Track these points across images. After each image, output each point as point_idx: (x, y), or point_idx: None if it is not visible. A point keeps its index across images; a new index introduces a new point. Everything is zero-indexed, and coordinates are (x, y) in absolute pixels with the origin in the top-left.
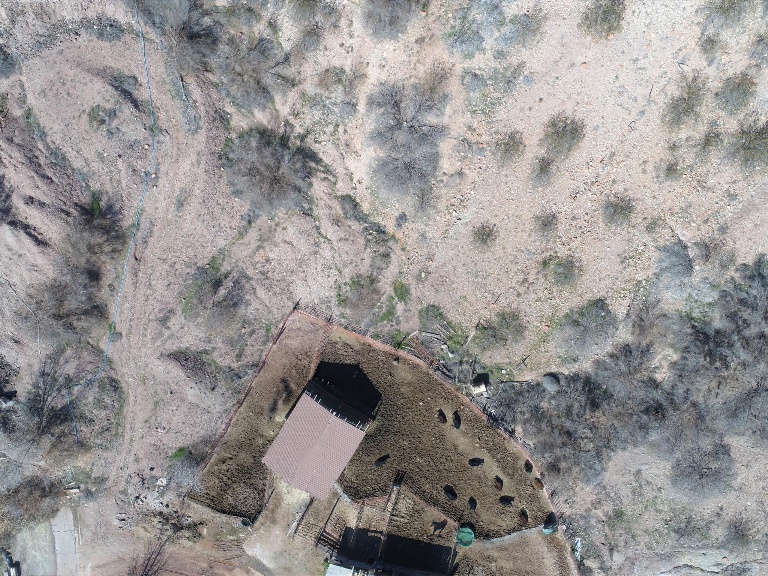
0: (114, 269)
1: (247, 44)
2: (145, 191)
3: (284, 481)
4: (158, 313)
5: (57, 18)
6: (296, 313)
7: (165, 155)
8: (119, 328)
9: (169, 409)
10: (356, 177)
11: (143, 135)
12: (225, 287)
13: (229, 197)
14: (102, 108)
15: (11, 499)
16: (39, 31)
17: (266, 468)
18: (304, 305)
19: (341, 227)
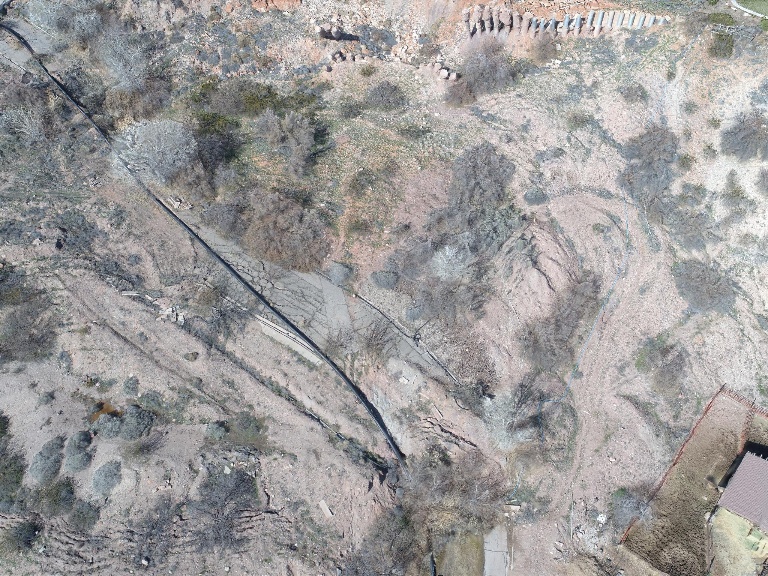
0: (585, 325)
1: (690, 215)
2: (616, 279)
3: (724, 550)
4: (617, 362)
5: (576, 183)
6: (721, 395)
7: (634, 261)
8: (581, 369)
9: (622, 441)
10: (767, 303)
11: (622, 246)
12: (672, 354)
13: (676, 295)
14: (602, 225)
15: (466, 493)
16: (566, 186)
17: (703, 533)
18: (729, 389)
19: (760, 333)
